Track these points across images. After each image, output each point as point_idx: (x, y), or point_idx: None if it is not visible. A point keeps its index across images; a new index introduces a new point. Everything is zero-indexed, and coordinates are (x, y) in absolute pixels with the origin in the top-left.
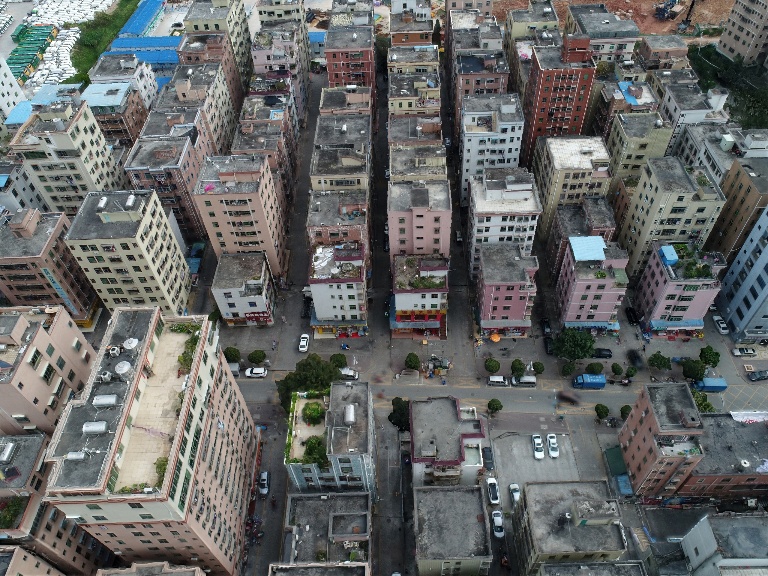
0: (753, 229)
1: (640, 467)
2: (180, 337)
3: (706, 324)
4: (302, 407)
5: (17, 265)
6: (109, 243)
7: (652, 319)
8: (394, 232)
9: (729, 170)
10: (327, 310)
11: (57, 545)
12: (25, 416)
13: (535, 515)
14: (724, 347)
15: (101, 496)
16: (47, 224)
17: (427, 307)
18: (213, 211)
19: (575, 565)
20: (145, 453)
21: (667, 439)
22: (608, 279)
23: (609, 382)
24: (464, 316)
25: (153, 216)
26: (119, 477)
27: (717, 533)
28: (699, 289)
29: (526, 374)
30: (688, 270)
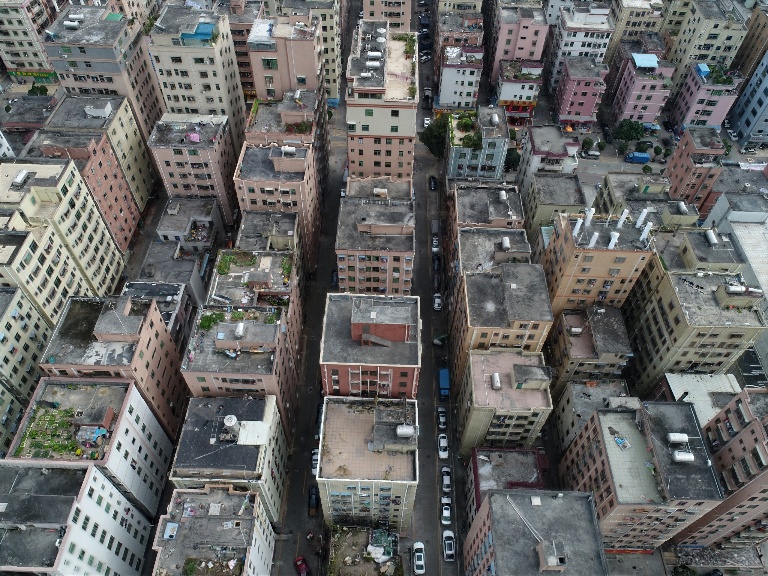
0: (764, 55)
1: (677, 188)
2: (400, 43)
3: (721, 135)
4: (456, 123)
5: (236, 30)
6: (313, 13)
7: (684, 123)
8: (502, 43)
9: (750, 18)
10: (449, 96)
11: (315, 168)
12: (305, 77)
13: (614, 187)
14: (734, 148)
15: (380, 100)
16: (251, 8)
17: (523, 98)
18: (373, 11)
19: (643, 200)
20: (397, 88)
21: (699, 158)
22: (659, 80)
23: (651, 160)
24: (544, 117)
25: (337, 4)
26: (385, 96)
27: (730, 200)
28: (722, 95)
29: (592, 150)
30: (716, 79)
